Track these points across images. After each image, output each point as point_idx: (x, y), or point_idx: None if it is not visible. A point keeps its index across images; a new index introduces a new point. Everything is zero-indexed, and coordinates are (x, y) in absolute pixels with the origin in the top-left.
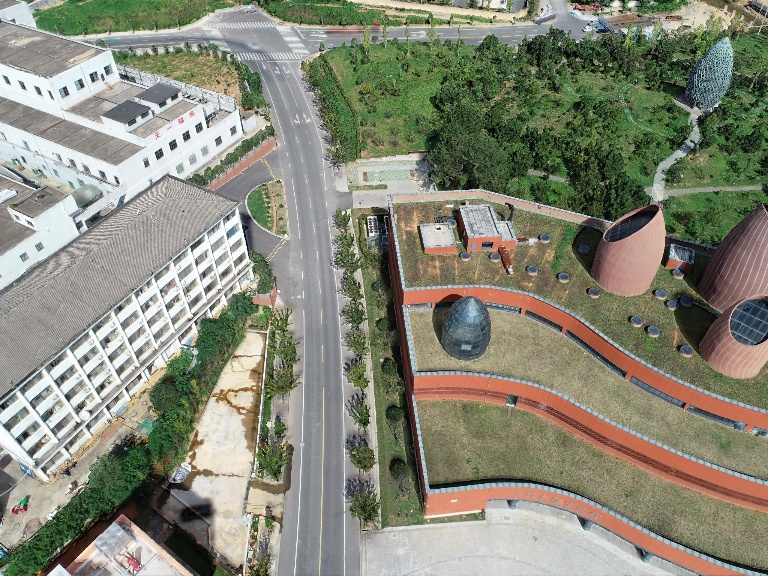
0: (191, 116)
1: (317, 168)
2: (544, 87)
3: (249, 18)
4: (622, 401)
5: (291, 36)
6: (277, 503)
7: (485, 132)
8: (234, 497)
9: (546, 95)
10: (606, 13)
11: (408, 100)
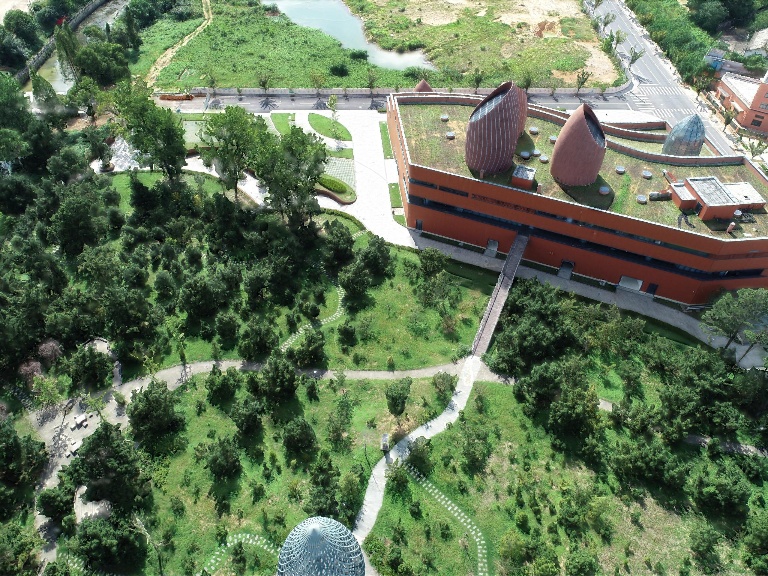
0: None
1: None
2: None
3: None
4: None
5: None
6: None
7: None
8: (767, 156)
9: None
10: None
11: None
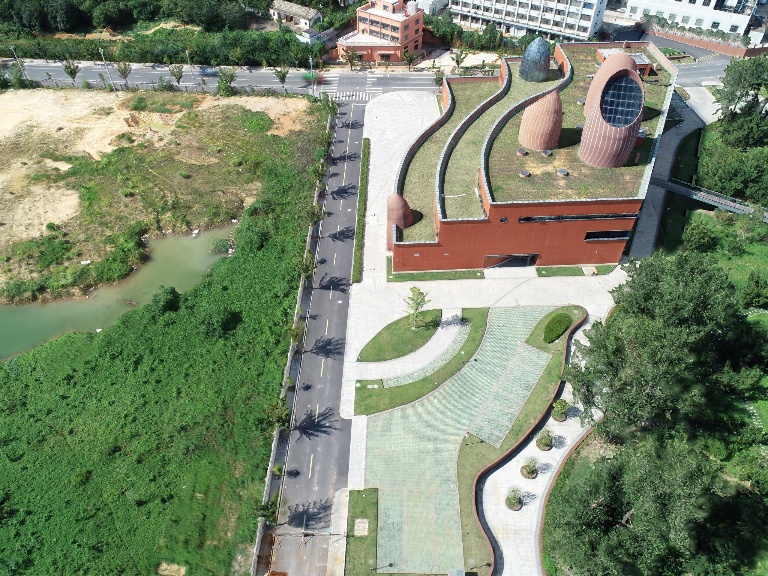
0: None
1: None
2: None
3: None
4: None
5: None
6: (446, 73)
7: None
8: (448, 63)
9: None
10: None
11: None
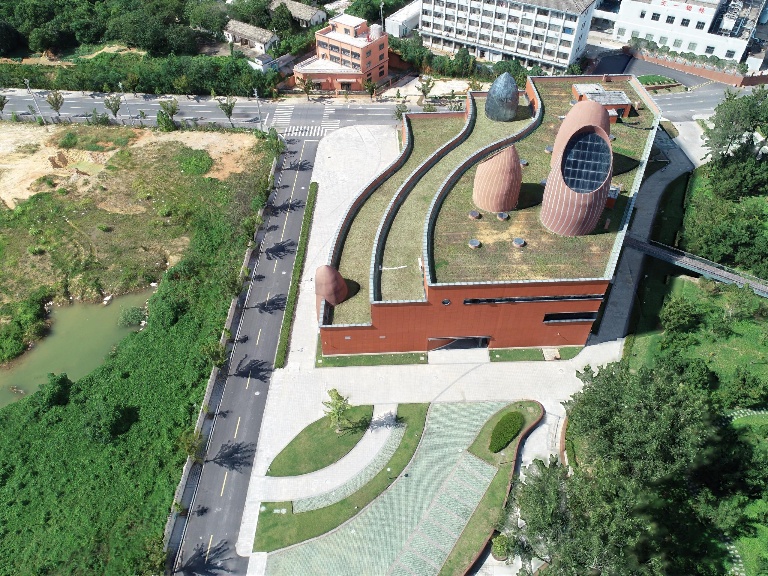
0: (700, 12)
1: None
2: None
3: None
4: None
5: None
6: (412, 103)
7: None
8: (415, 92)
9: None
10: None
11: None
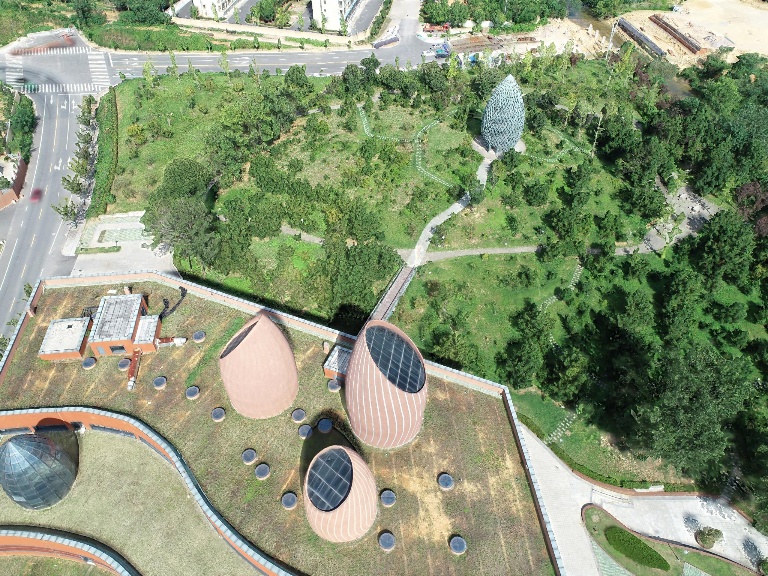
0: None
1: (52, 226)
2: (339, 126)
3: (62, 43)
4: (200, 569)
5: (99, 64)
6: None
7: (253, 181)
8: None
9: (336, 136)
10: (455, 35)
11: (181, 143)
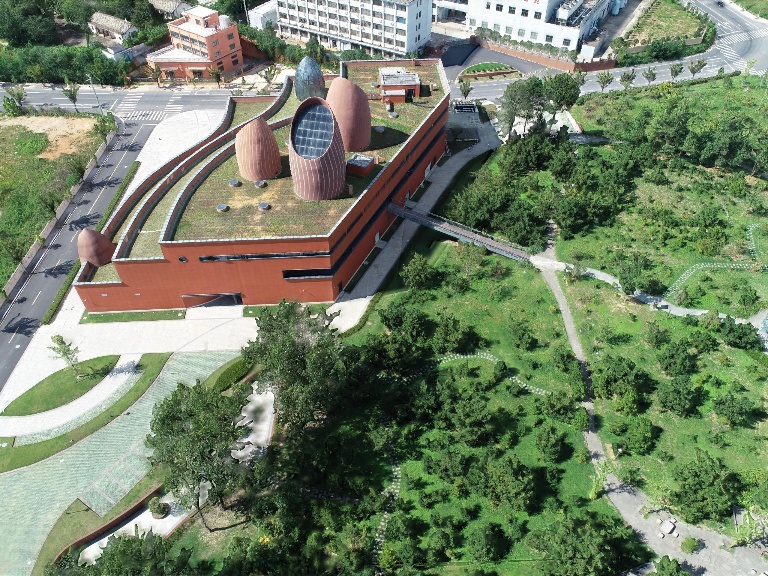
0: (536, 2)
1: None
2: None
3: None
4: None
5: None
6: None
7: None
8: None
9: (732, 201)
10: None
11: None
